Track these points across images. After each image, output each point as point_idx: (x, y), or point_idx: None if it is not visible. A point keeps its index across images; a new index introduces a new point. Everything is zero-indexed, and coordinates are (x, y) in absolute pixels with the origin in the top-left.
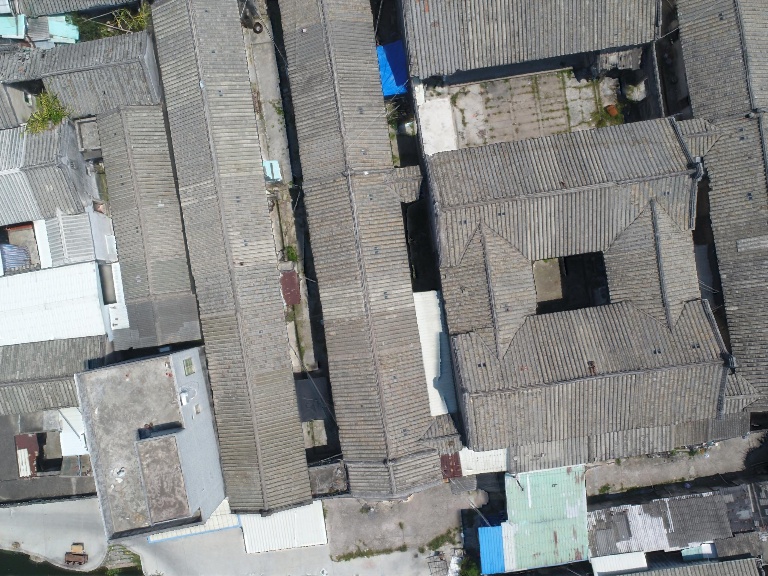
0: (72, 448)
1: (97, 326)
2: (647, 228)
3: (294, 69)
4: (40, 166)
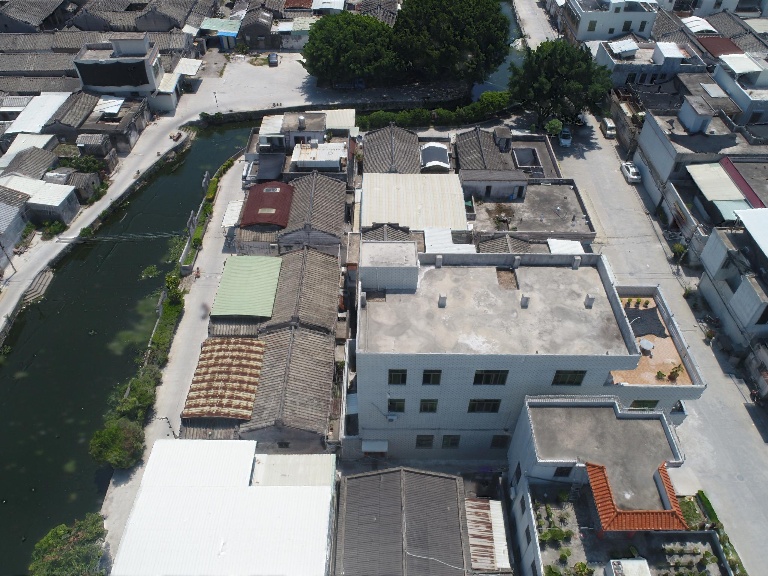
0: (115, 109)
1: (64, 97)
2: None
3: (5, 48)
4: None
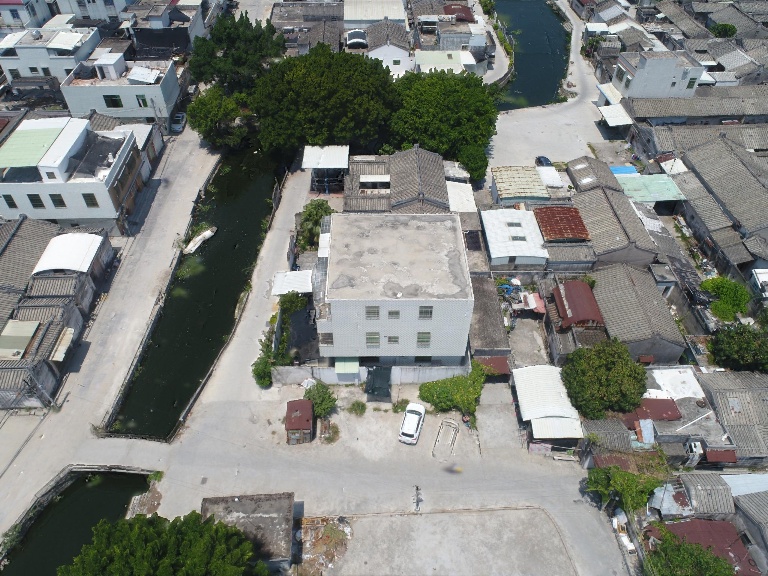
0: None
1: None
2: None
3: None
4: None
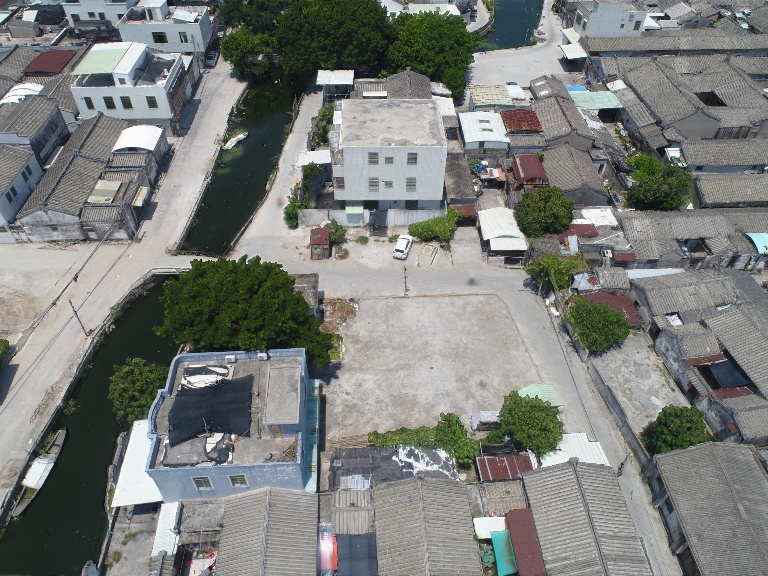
0: None
1: None
2: None
3: None
4: None
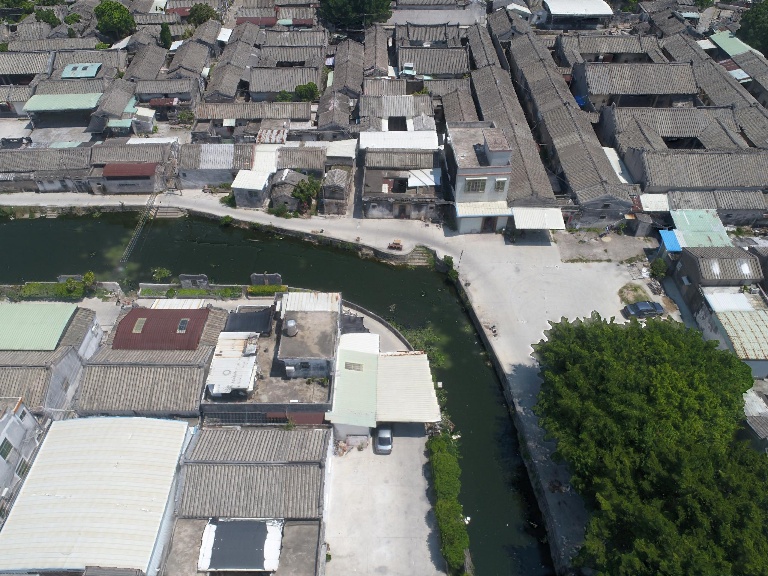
0: (415, 183)
1: (435, 147)
2: (716, 125)
3: (534, 90)
4: (422, 95)
